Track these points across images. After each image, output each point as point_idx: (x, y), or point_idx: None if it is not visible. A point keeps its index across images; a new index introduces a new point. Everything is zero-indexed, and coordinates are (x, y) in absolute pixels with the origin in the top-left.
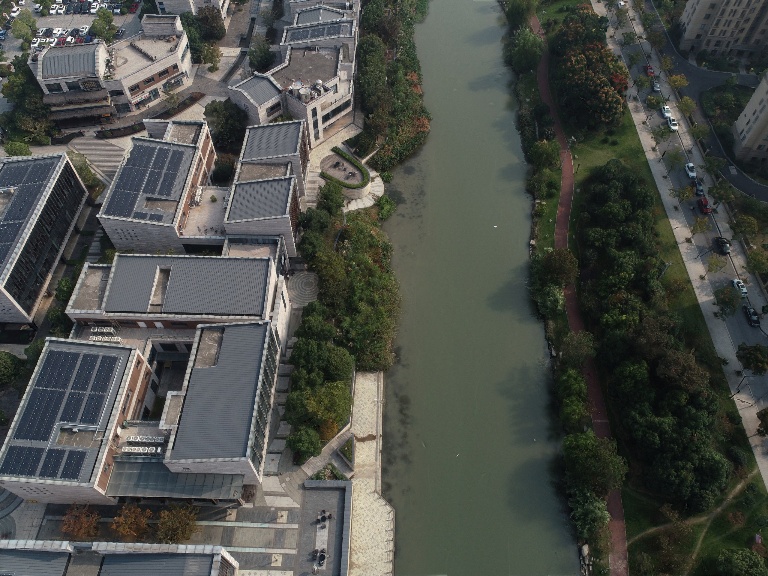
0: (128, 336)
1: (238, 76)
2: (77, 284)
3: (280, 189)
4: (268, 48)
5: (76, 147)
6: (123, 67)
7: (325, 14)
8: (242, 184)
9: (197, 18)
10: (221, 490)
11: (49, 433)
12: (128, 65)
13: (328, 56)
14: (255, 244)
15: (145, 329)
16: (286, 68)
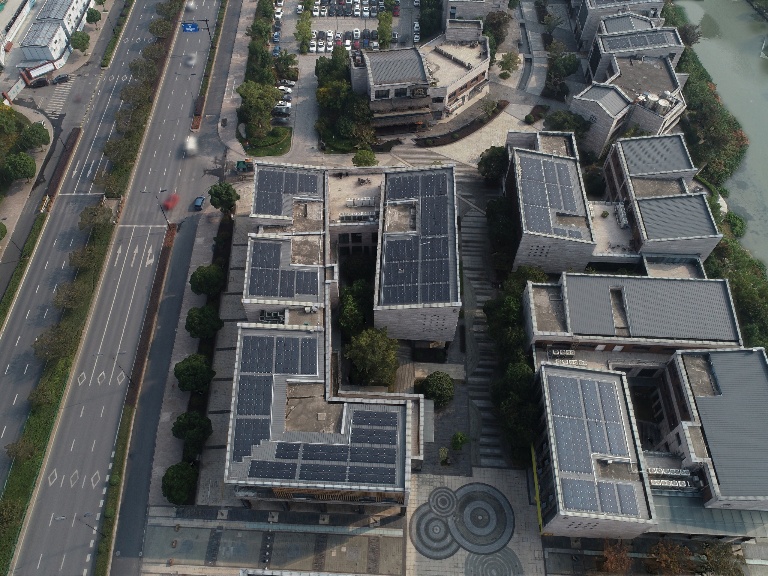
0: (585, 359)
1: (533, 84)
2: (531, 304)
3: (693, 206)
4: (562, 55)
5: (400, 155)
6: (438, 73)
7: (635, 22)
8: (644, 200)
9: (487, 23)
10: (765, 528)
11: (590, 465)
12: (442, 71)
13: (657, 66)
14: (669, 263)
15: (599, 352)
16: (620, 78)
